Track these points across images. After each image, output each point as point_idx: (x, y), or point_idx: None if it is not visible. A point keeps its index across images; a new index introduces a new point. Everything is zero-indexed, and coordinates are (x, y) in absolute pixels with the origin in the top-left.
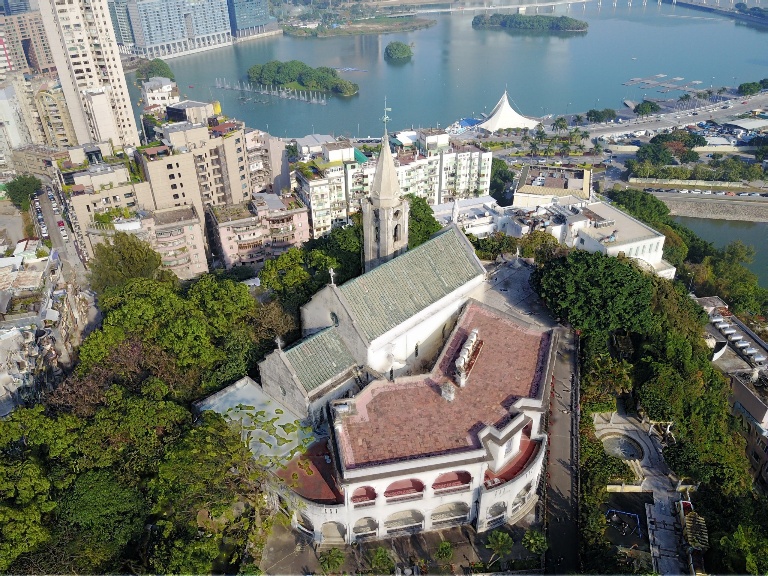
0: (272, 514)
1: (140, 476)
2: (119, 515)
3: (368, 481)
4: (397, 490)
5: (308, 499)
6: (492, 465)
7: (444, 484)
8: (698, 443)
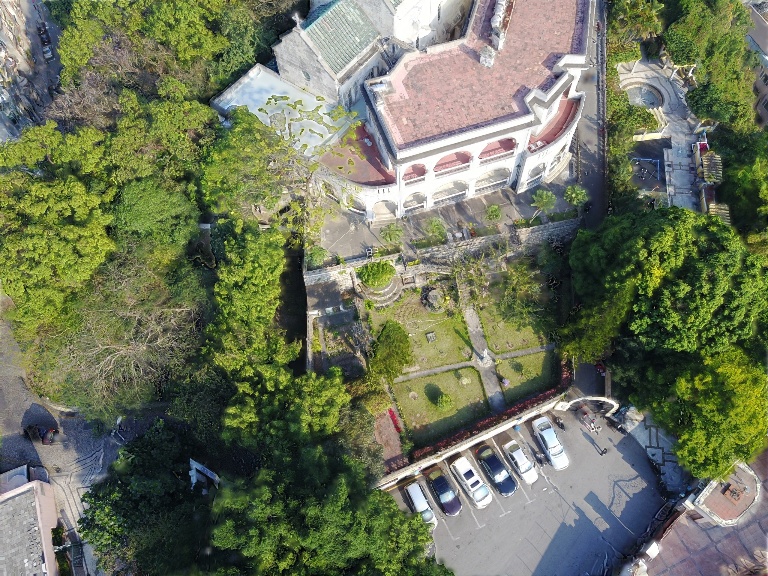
0: (319, 200)
1: (176, 180)
2: (173, 219)
3: (421, 159)
4: (443, 164)
5: (358, 183)
6: (533, 129)
7: (487, 153)
8: (715, 83)
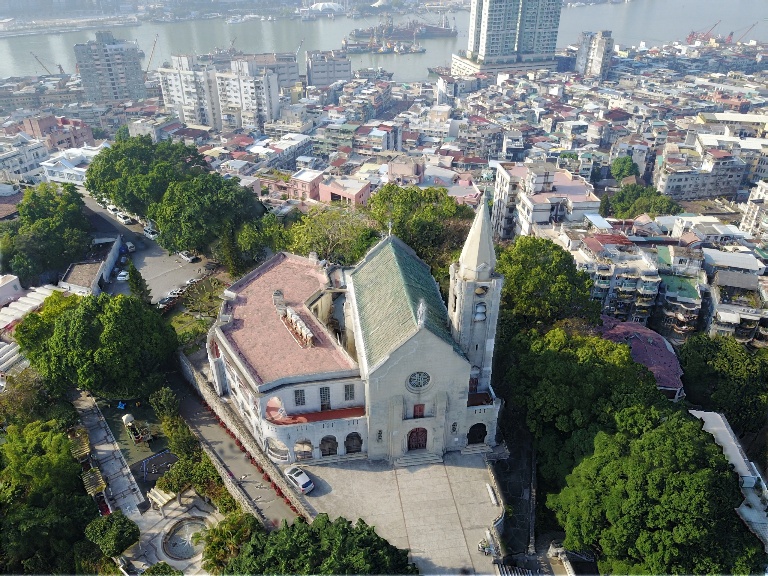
0: None
1: None
2: None
3: None
4: None
5: None
6: None
7: None
8: None
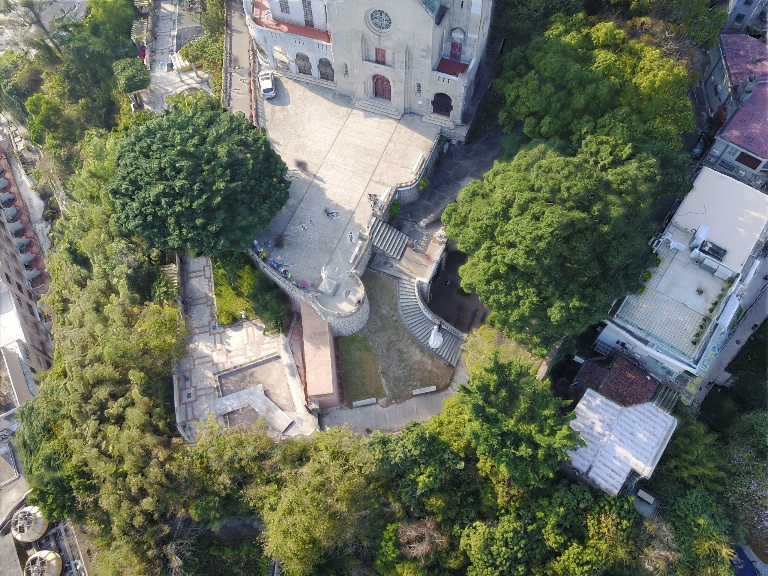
0: None
1: None
2: None
3: None
4: None
5: None
6: None
7: None
8: None
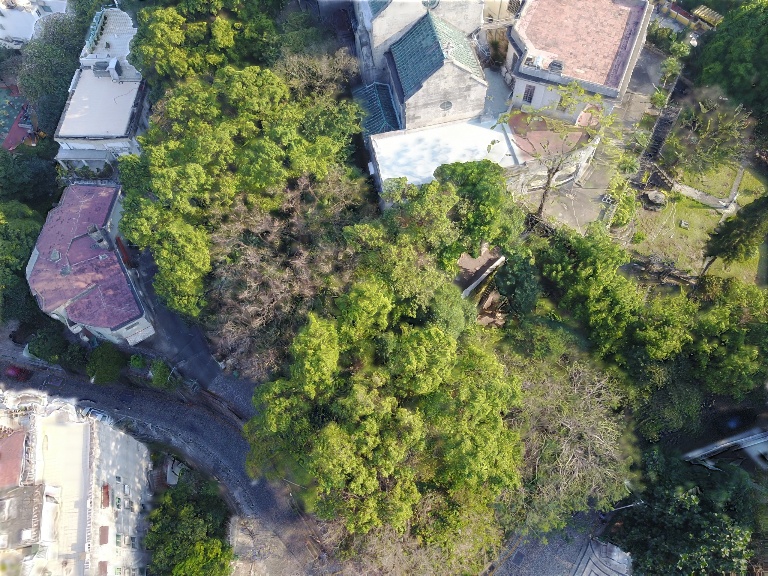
0: (523, 201)
1: None
2: None
3: None
4: None
5: (574, 149)
6: None
7: None
8: None
